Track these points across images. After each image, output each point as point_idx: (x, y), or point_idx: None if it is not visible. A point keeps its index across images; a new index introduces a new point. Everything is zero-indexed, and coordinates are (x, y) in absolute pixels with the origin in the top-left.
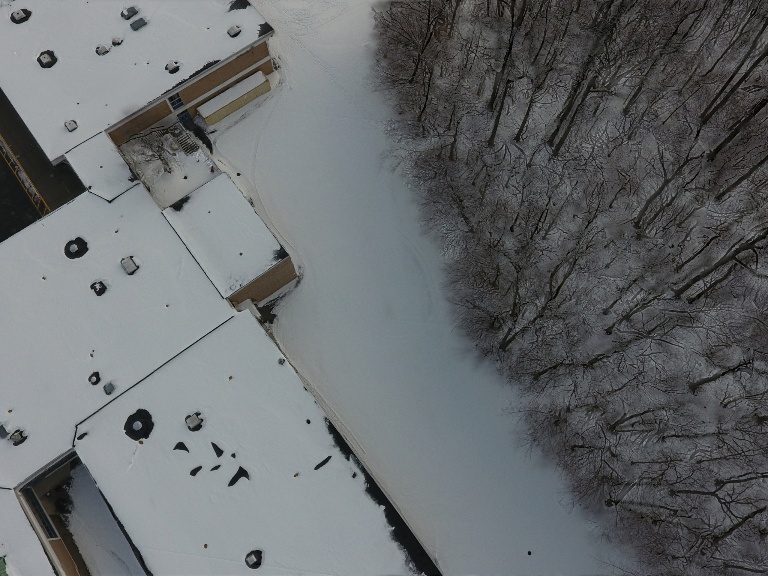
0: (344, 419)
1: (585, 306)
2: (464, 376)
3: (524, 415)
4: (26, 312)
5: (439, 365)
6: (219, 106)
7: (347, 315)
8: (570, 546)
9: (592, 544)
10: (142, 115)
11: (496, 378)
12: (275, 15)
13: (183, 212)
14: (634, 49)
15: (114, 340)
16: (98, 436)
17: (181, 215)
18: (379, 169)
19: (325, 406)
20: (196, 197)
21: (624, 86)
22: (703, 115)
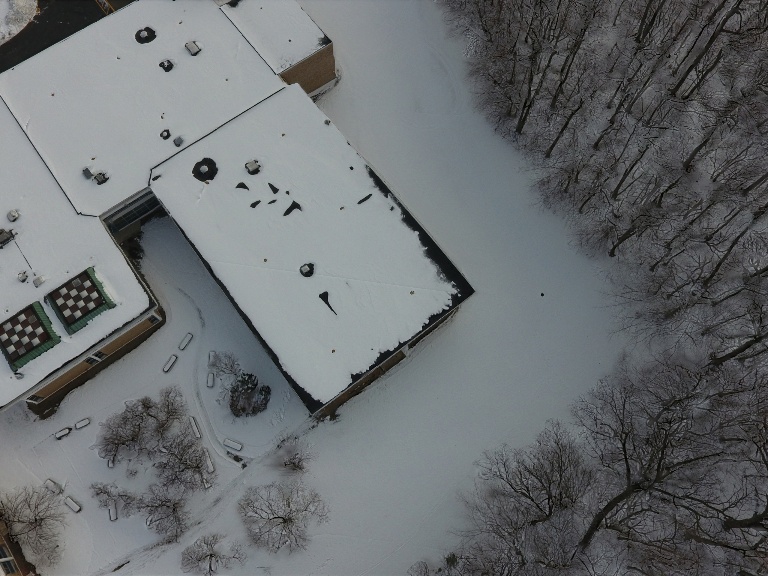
0: (382, 173)
1: None
2: (485, 155)
3: (538, 183)
4: (104, 83)
5: (462, 148)
6: None
7: (380, 108)
8: (578, 286)
9: (597, 283)
10: None
11: (513, 155)
12: None
13: (238, 8)
14: None
15: (181, 105)
16: (170, 178)
17: (237, 10)
18: None
19: (365, 159)
20: None
21: None
22: None
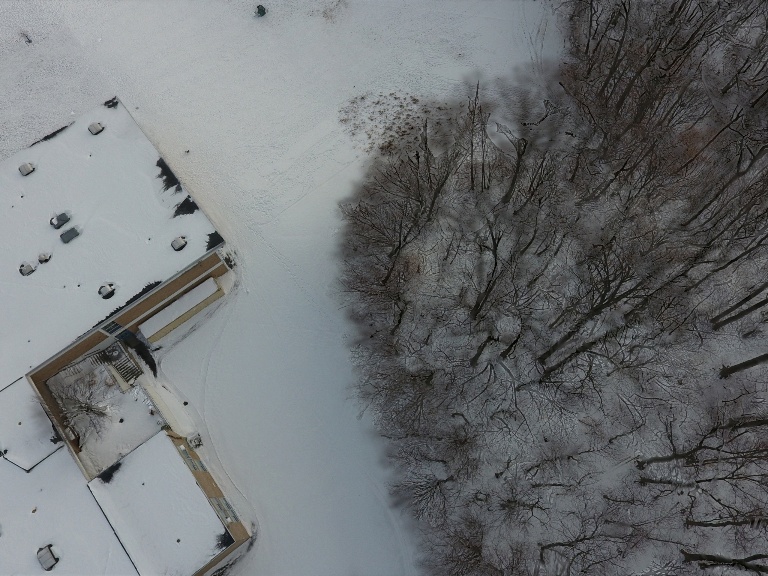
0: None
1: None
2: None
3: None
4: None
5: None
6: (163, 323)
7: None
8: None
9: None
10: (71, 350)
11: None
12: (232, 199)
13: (113, 484)
14: (636, 237)
15: None
16: None
17: (110, 488)
18: (346, 396)
19: None
20: (128, 464)
21: (625, 304)
22: (715, 320)
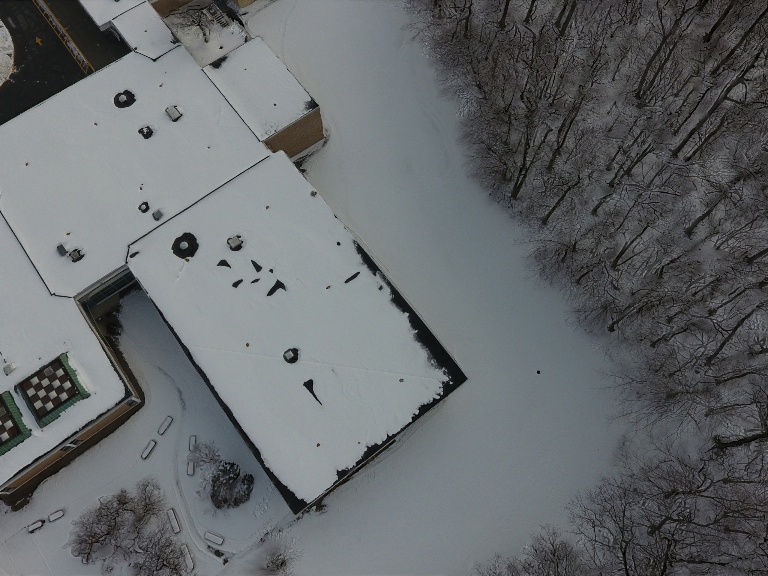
0: (370, 246)
1: (590, 162)
2: (478, 221)
3: (534, 253)
4: (80, 152)
5: (455, 213)
6: None
7: (370, 171)
8: (576, 364)
9: (596, 361)
10: None
11: (508, 222)
12: None
13: (221, 69)
14: None
15: (161, 176)
16: (148, 254)
17: (220, 72)
18: (399, 46)
19: (353, 233)
20: (233, 57)
21: None
22: (700, 2)
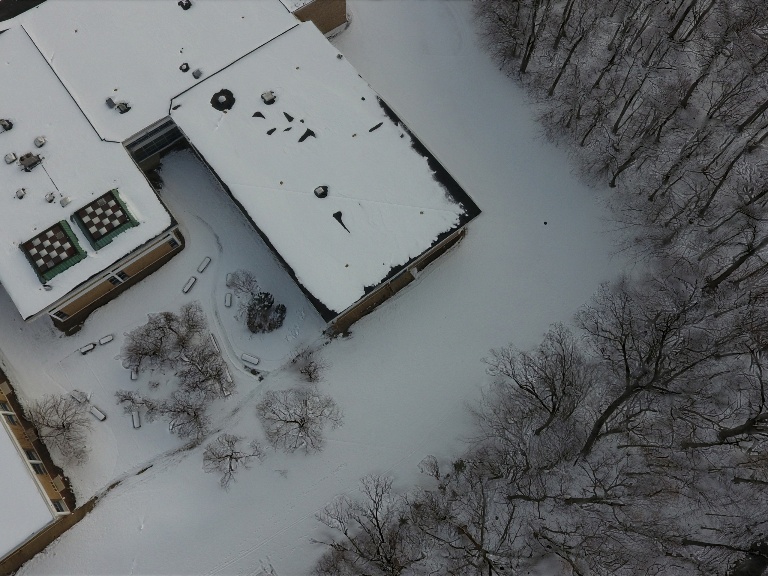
0: None
1: (593, 42)
2: (490, 93)
3: (541, 119)
4: (125, 20)
5: (468, 87)
6: None
7: (390, 50)
8: (580, 214)
9: (598, 211)
10: None
11: (517, 93)
12: None
13: None
14: None
15: (199, 41)
16: (190, 107)
17: None
18: None
19: None
20: None
21: None
22: None
